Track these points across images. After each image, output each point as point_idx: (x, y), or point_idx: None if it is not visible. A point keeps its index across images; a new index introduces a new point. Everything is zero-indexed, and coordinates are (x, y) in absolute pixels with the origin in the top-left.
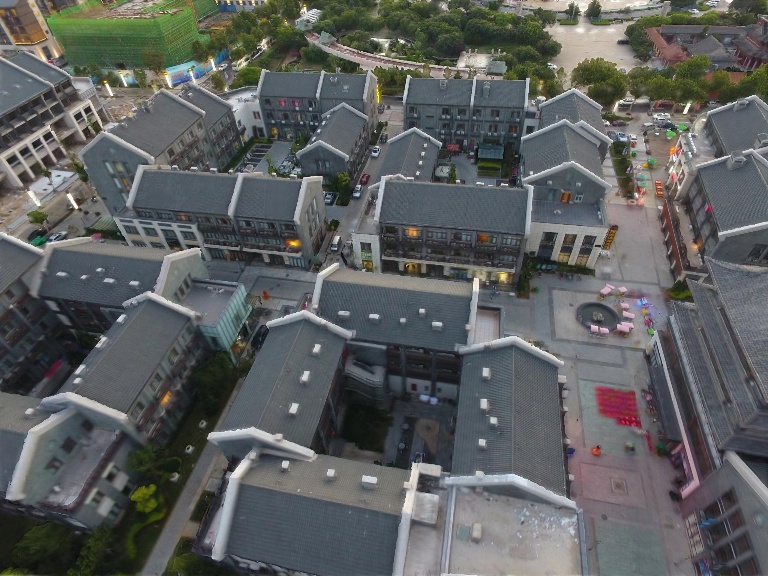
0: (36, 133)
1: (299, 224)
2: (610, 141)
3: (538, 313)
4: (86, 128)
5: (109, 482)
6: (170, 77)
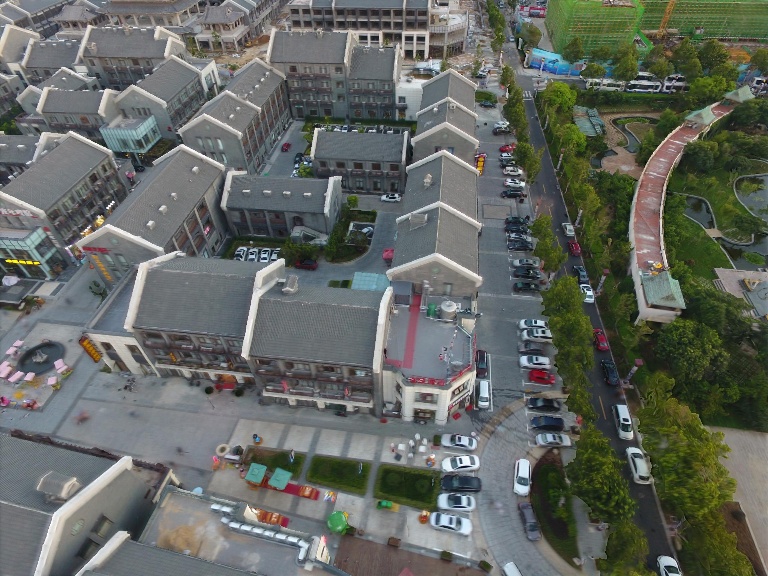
0: (368, 31)
1: (182, 136)
2: (243, 351)
3: (75, 313)
4: (411, 50)
5: (36, 131)
6: (533, 58)
